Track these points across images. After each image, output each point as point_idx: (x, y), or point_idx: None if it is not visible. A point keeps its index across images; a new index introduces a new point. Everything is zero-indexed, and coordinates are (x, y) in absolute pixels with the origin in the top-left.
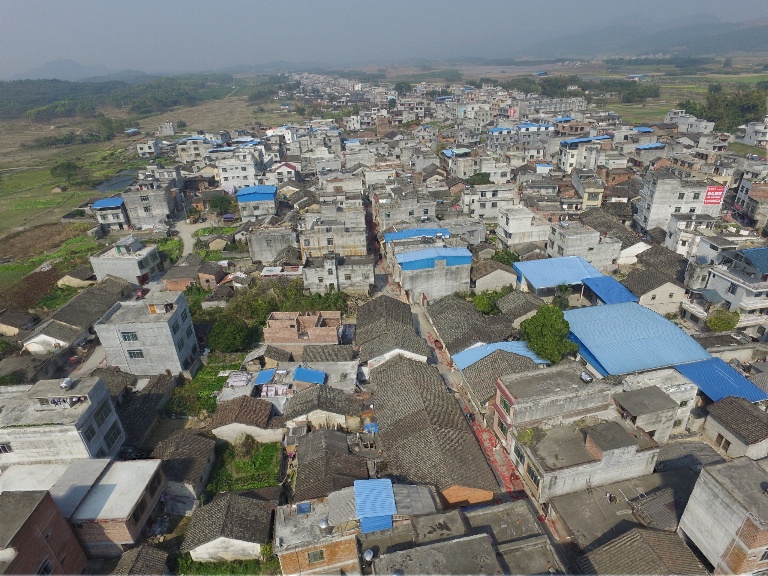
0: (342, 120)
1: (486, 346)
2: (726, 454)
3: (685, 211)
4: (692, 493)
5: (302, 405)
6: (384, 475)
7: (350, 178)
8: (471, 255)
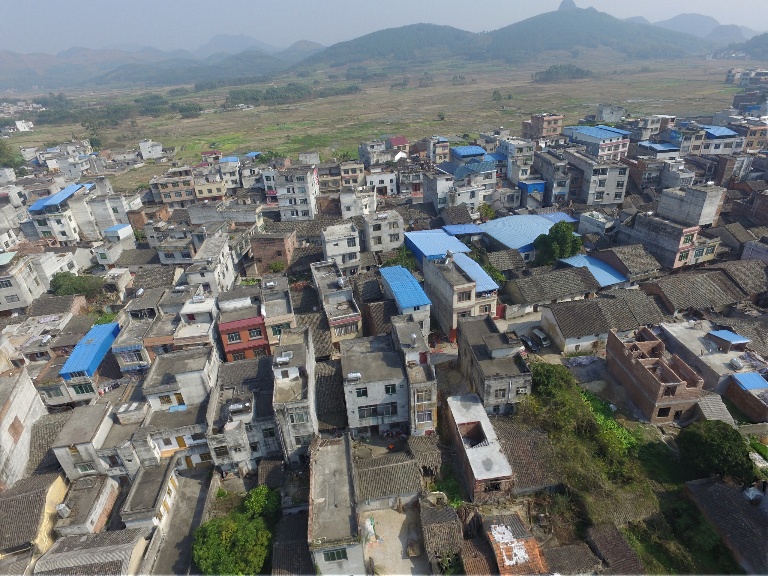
0: None
1: None
2: None
3: (315, 195)
4: (704, 206)
5: (764, 337)
6: (758, 306)
7: (14, 386)
8: None
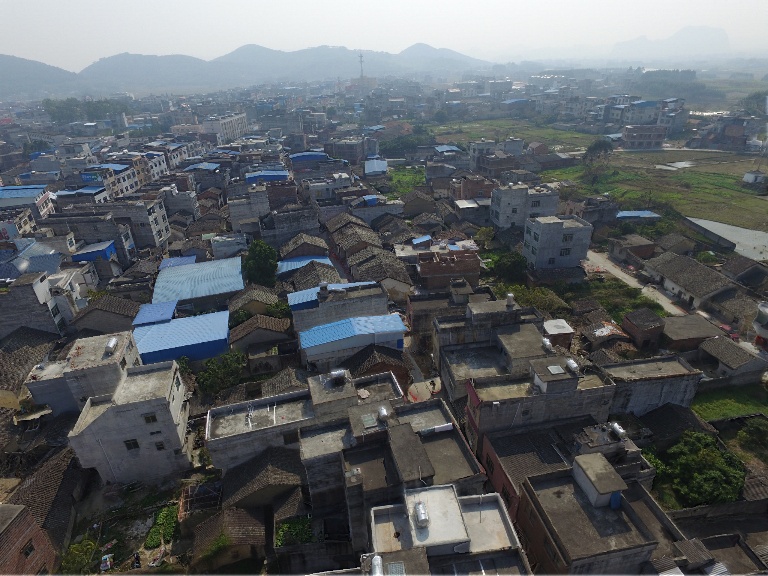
0: None
1: None
2: None
3: None
4: None
5: None
6: None
7: None
8: None
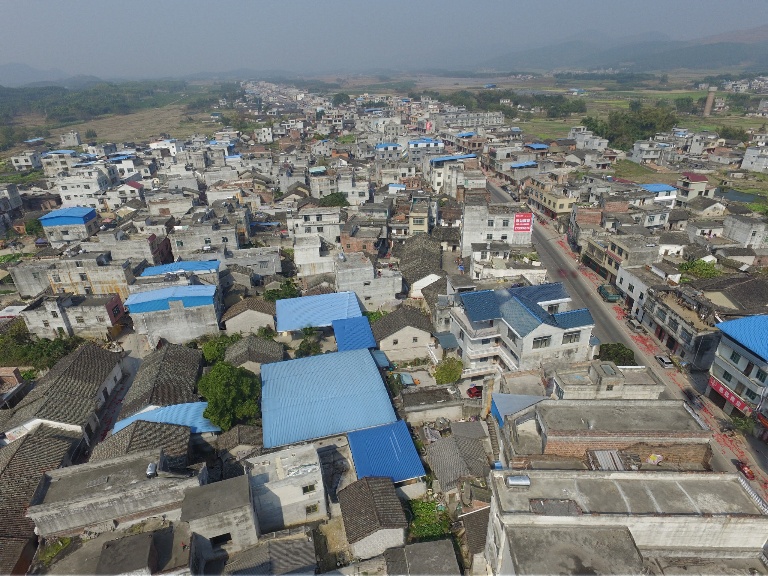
0: (254, 132)
1: (159, 410)
2: (350, 548)
3: (497, 238)
4: None
5: None
6: None
7: (177, 199)
8: (212, 295)
